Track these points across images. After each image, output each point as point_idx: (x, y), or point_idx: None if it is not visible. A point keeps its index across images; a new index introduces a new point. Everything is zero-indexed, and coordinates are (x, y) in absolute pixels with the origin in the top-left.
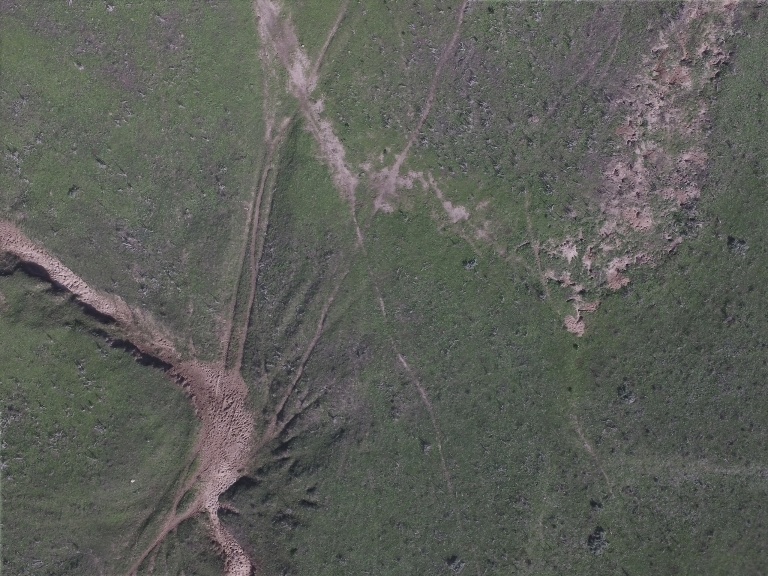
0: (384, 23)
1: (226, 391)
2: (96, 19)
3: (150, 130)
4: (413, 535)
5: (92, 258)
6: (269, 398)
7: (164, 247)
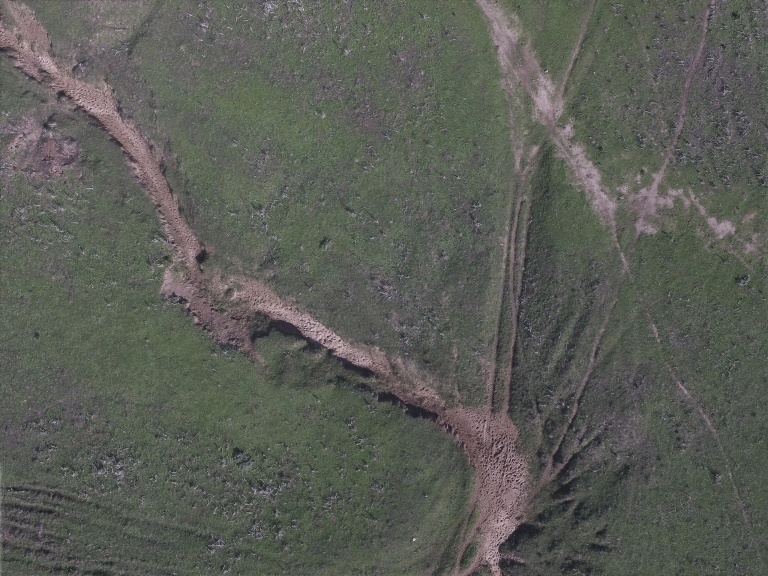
0: (627, 40)
1: (494, 436)
2: (332, 65)
3: (398, 173)
4: (713, 570)
5: (349, 311)
6: (543, 439)
7: (422, 292)
